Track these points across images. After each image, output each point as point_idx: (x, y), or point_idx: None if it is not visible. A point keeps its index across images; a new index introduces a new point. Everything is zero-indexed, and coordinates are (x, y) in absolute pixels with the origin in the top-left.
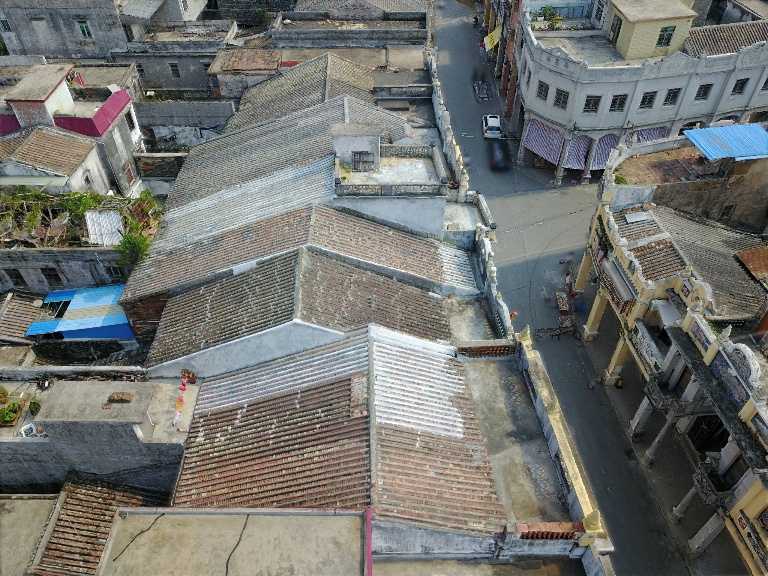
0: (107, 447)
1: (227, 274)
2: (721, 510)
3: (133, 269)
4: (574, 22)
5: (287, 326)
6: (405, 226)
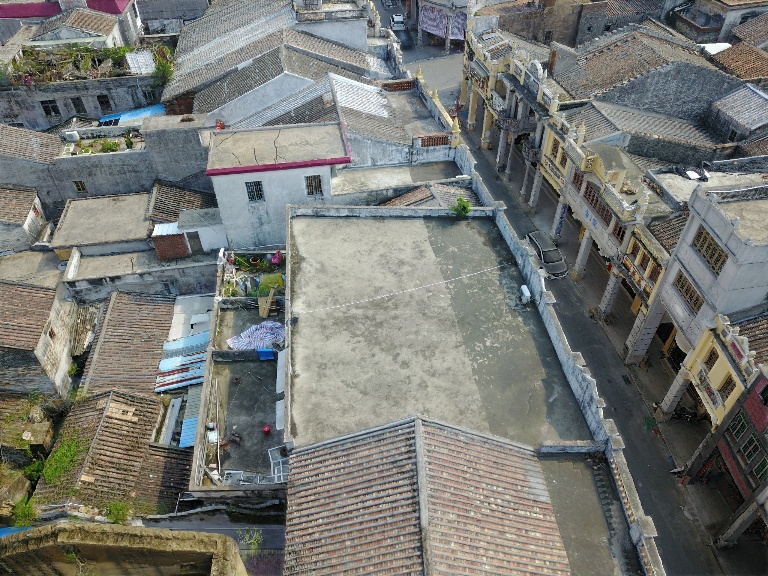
0: (181, 153)
1: (234, 71)
2: (538, 165)
3: (165, 87)
4: None
5: (281, 76)
6: (342, 43)
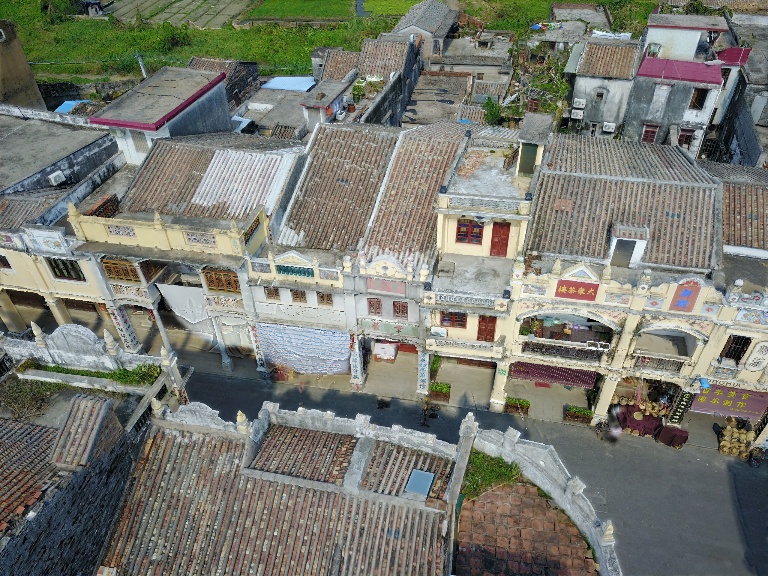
0: None
1: None
2: None
3: None
4: None
5: None
6: None
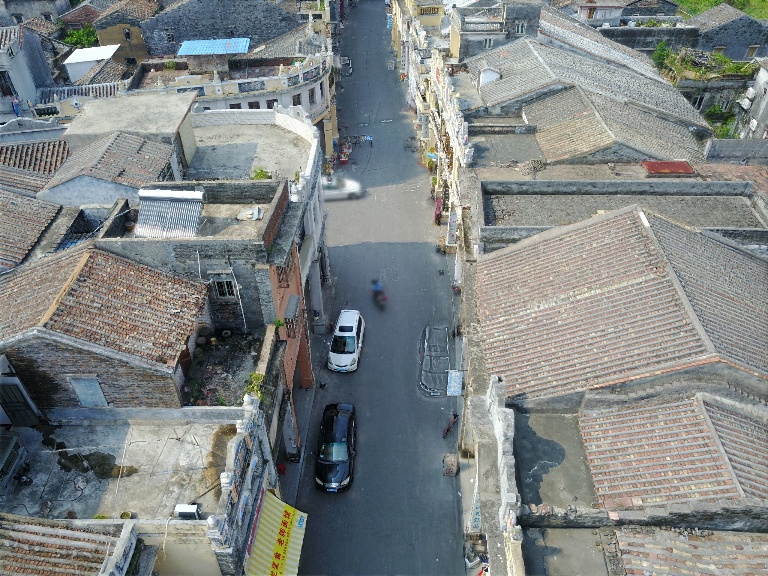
0: None
1: None
2: None
3: None
4: (229, 172)
5: None
6: None
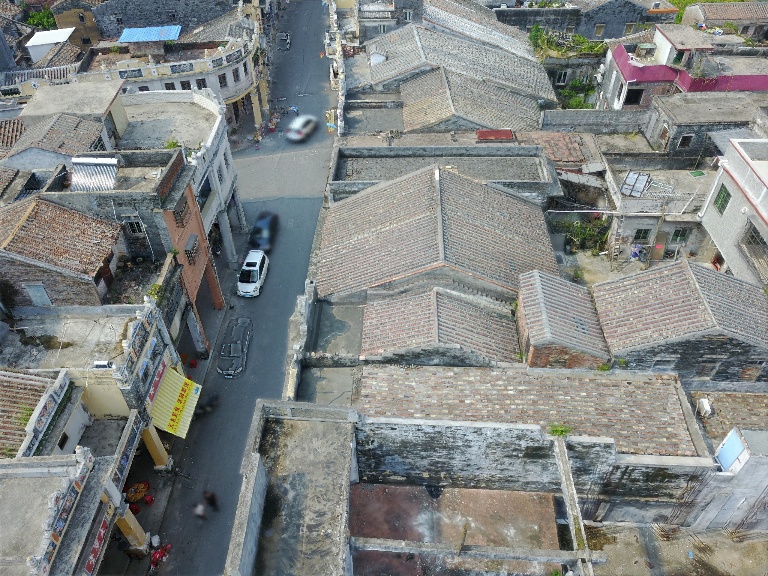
0: None
1: None
2: None
3: None
4: None
5: None
6: None
